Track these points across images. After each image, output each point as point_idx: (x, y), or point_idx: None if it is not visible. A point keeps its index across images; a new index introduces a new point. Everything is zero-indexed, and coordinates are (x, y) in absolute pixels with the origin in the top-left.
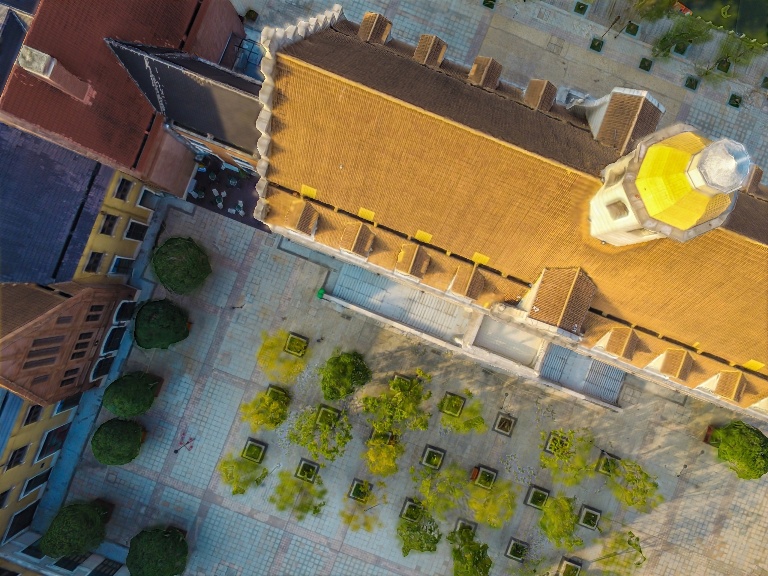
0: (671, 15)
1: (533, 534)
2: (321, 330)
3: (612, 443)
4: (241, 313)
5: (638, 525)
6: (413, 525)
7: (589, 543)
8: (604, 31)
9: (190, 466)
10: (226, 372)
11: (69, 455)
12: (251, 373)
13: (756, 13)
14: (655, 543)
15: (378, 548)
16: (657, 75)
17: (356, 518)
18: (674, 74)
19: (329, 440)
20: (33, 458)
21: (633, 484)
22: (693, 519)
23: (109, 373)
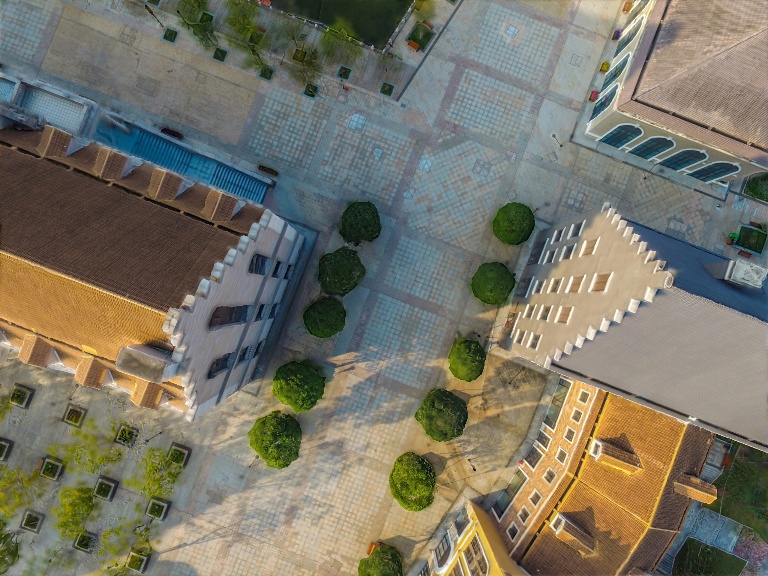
0: (201, 4)
1: (102, 525)
2: None
3: (183, 434)
4: None
5: (208, 516)
6: None
7: (158, 534)
8: (178, 21)
9: None
10: None
11: None
12: None
13: (340, 3)
14: (225, 534)
15: None
16: (231, 65)
17: None
18: (249, 64)
19: None
20: None
21: (153, 474)
22: (264, 510)
23: None
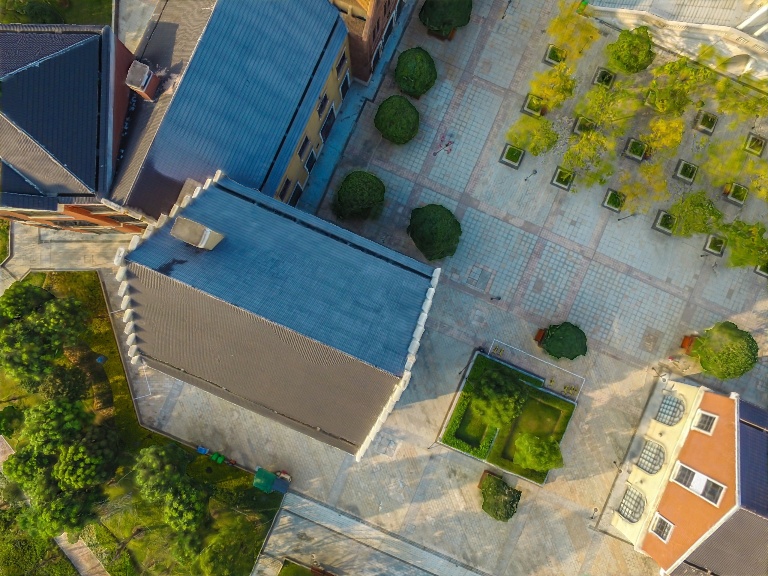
0: None
1: None
2: (579, 44)
3: None
4: (502, 24)
5: None
6: (696, 201)
7: None
8: None
9: (448, 169)
10: (486, 80)
11: (331, 152)
12: (510, 82)
13: None
14: None
15: (630, 258)
16: None
17: (609, 227)
18: None
19: (585, 150)
20: (321, 124)
21: None
22: None
23: (373, 74)
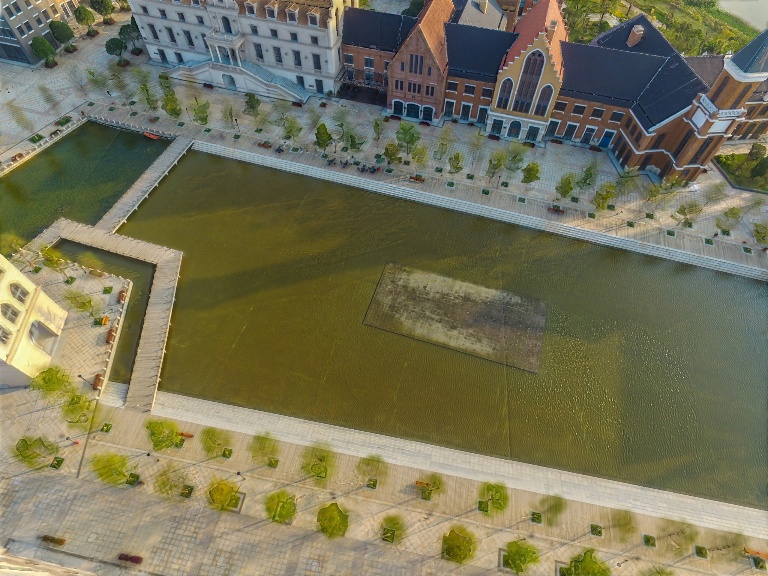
0: None
1: None
2: None
3: None
4: None
5: None
6: None
7: None
8: None
9: (397, 9)
10: None
11: None
12: None
13: (105, 138)
14: None
15: None
16: None
17: None
18: None
19: None
20: None
21: None
22: None
23: None
